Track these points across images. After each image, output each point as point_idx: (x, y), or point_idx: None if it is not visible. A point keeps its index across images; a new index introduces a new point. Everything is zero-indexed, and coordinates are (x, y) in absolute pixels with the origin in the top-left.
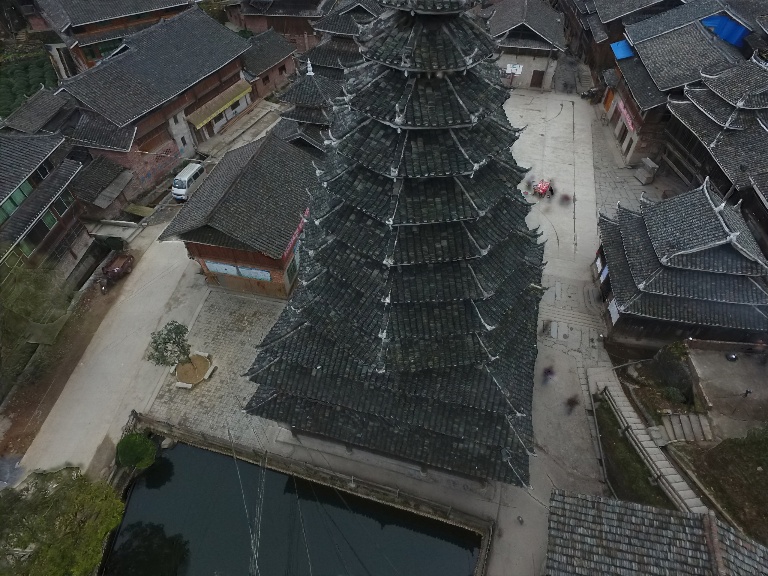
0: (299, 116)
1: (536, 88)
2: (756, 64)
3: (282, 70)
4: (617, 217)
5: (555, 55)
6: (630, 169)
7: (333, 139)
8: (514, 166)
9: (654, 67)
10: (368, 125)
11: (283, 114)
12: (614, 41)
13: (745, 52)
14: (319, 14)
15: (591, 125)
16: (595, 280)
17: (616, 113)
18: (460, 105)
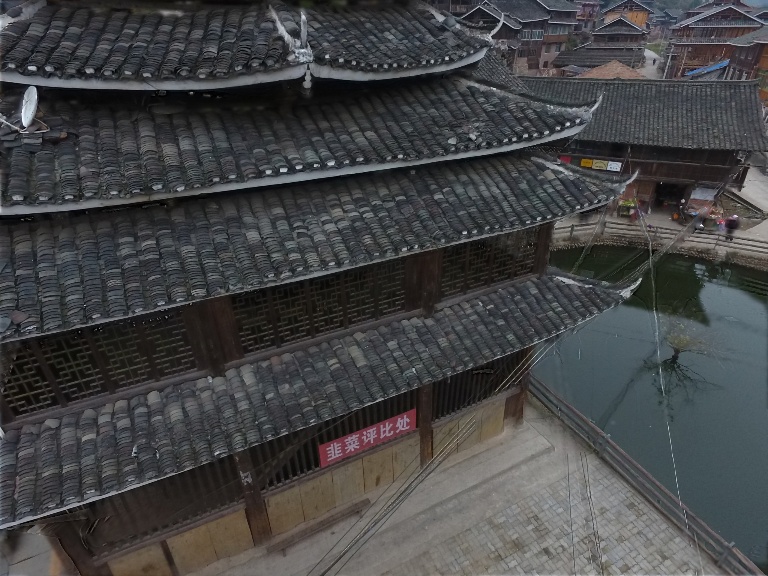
0: None
1: None
2: None
3: None
4: None
5: None
6: None
7: None
8: None
9: None
10: None
11: None
12: None
13: None
14: None
15: None
16: None
17: None
18: None
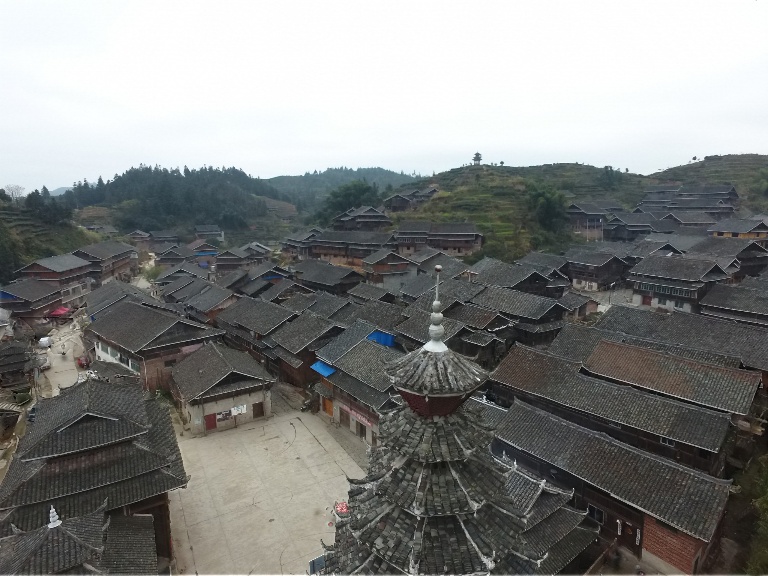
0: None
1: (259, 418)
2: None
3: None
4: None
5: (267, 387)
6: None
7: None
8: None
9: (362, 376)
10: None
11: None
12: (308, 363)
13: (399, 348)
14: None
15: (328, 432)
16: None
17: (343, 415)
18: (506, 515)
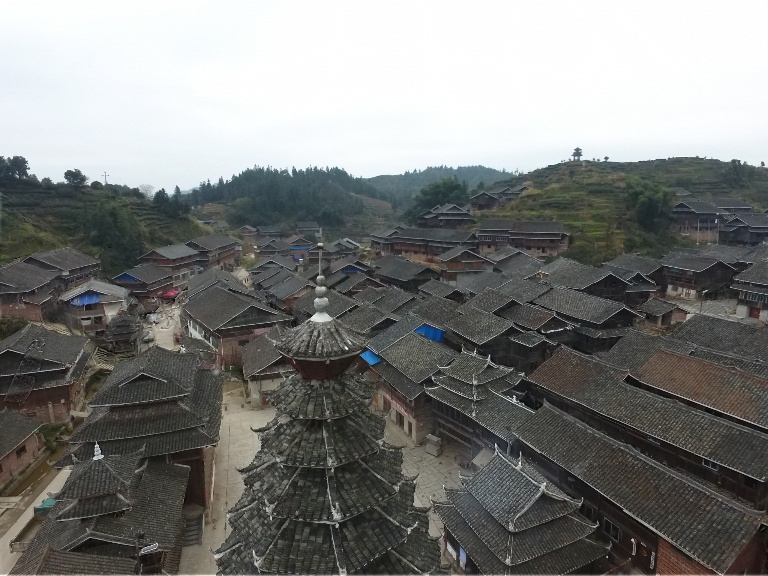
0: (85, 511)
1: None
2: (467, 354)
3: (21, 452)
4: (449, 499)
5: None
6: (420, 447)
7: (257, 558)
8: (418, 509)
9: (402, 367)
10: (288, 526)
11: (60, 516)
12: None
13: (448, 344)
14: (69, 382)
15: None
16: (456, 569)
17: (386, 404)
18: (379, 480)
